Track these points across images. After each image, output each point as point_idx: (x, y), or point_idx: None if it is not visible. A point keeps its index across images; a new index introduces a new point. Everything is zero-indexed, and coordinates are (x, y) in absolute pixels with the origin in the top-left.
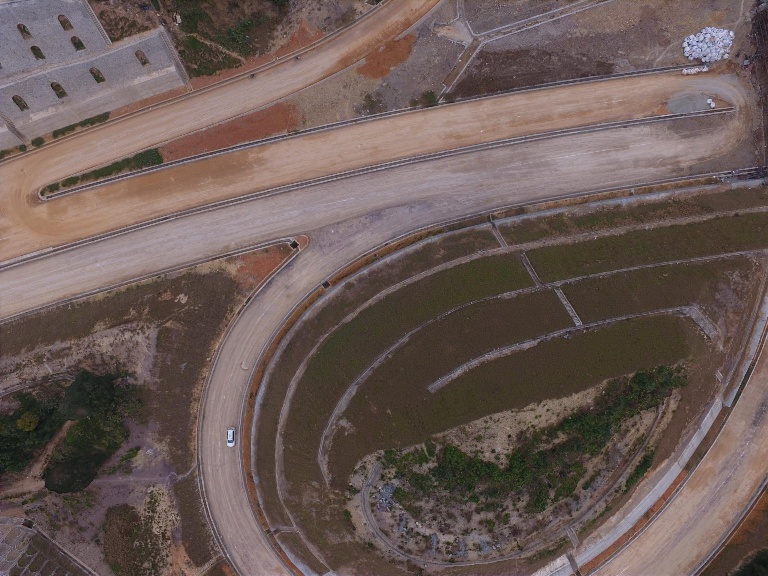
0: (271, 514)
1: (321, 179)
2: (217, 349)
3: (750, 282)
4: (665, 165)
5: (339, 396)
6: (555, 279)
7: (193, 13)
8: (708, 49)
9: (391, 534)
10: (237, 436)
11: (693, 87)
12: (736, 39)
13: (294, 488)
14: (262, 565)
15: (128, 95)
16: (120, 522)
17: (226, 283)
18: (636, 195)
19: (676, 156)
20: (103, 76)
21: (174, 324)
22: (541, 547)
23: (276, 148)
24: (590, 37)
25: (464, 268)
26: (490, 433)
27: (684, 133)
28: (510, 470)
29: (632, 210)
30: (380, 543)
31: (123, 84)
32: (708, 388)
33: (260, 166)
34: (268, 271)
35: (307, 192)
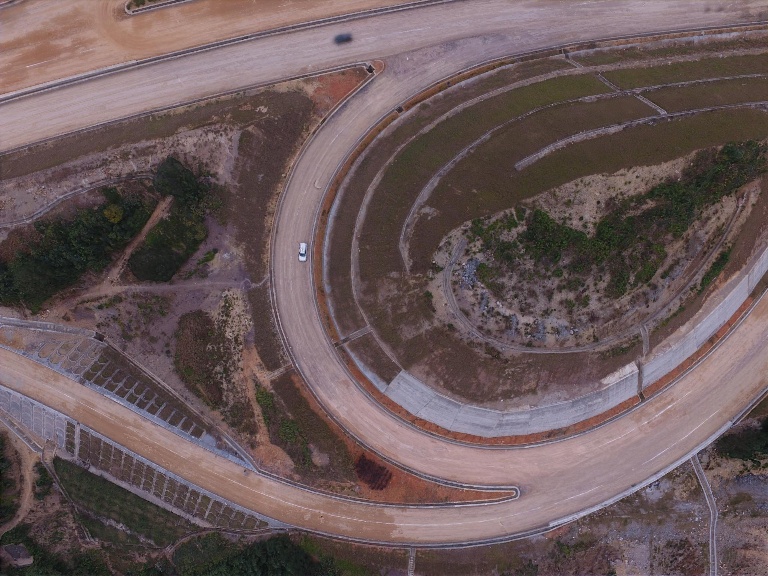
0: (342, 322)
1: (398, 7)
2: (292, 166)
3: None
4: (735, 10)
5: (421, 186)
6: (635, 86)
7: None
8: None
9: (472, 313)
10: (309, 252)
11: None
12: None
13: (370, 286)
14: (329, 377)
15: None
16: (194, 326)
17: (303, 101)
18: None
19: (746, 2)
20: None
21: (255, 130)
22: (615, 342)
23: None
24: None
25: (541, 84)
26: (579, 198)
27: None
28: (597, 237)
29: (704, 45)
30: (460, 324)
31: None
32: None
33: None
34: (344, 93)
35: (384, 19)
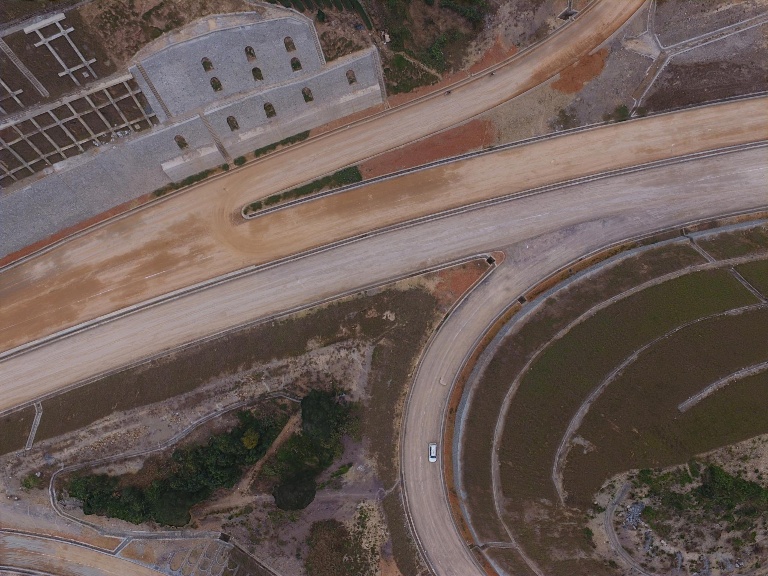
0: (480, 529)
1: (516, 195)
2: (417, 365)
3: None
4: None
5: (572, 414)
6: None
7: (401, 32)
8: None
9: (635, 552)
10: (438, 451)
11: None
12: None
13: (515, 504)
14: None
15: (331, 114)
16: (329, 537)
17: (427, 299)
18: None
19: None
20: (312, 96)
21: (386, 341)
22: None
23: (471, 164)
24: None
25: (676, 284)
26: (756, 453)
27: None
28: None
29: None
30: (622, 561)
31: (329, 103)
32: None
33: (456, 182)
34: (466, 287)
35: (502, 208)
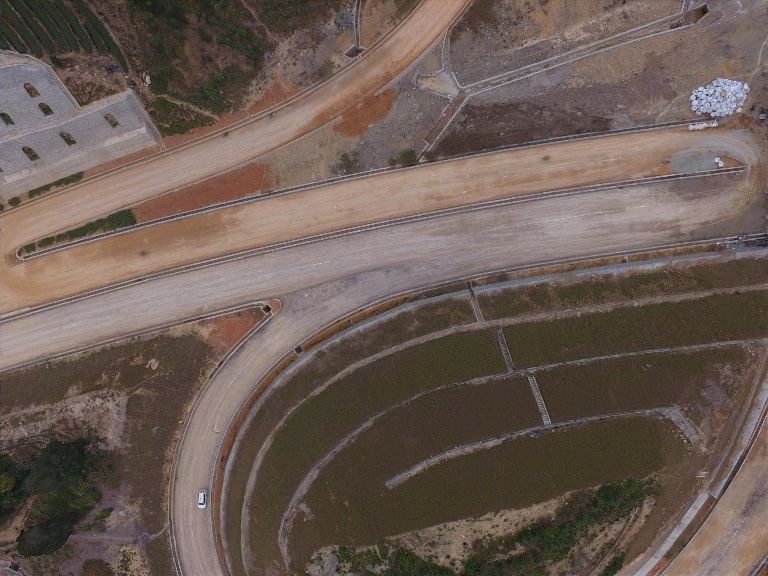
0: None
1: (295, 242)
2: (189, 412)
3: (742, 376)
4: (664, 229)
5: (300, 479)
6: (529, 365)
7: (163, 73)
8: (718, 104)
9: None
10: (208, 498)
11: (700, 144)
12: (751, 91)
13: (258, 561)
14: None
15: (100, 156)
16: None
17: (198, 347)
18: (629, 262)
19: (676, 220)
20: (74, 139)
21: (144, 391)
22: None
23: (250, 209)
24: (587, 88)
25: (436, 345)
26: (444, 540)
27: (687, 195)
28: None
29: (623, 281)
30: None
31: (94, 146)
32: (687, 490)
33: (233, 227)
34: (240, 335)
35: (281, 255)
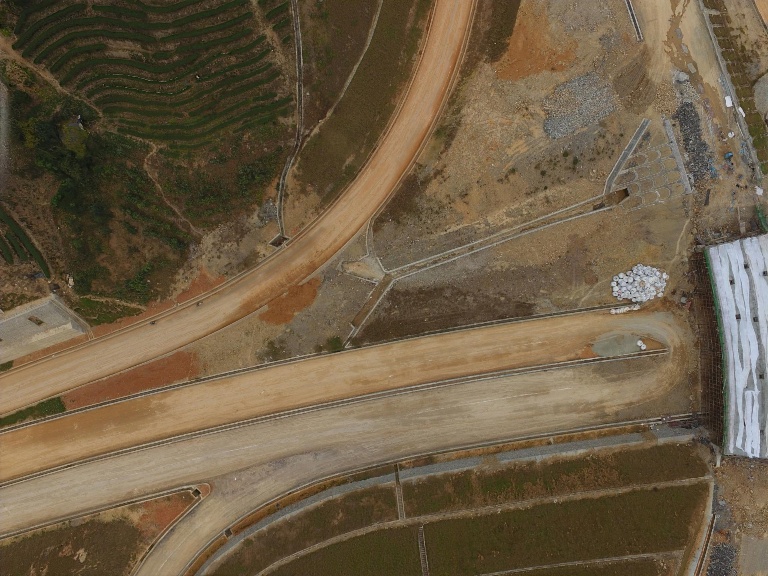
0: None
1: (223, 427)
2: None
3: None
4: (588, 411)
5: None
6: None
7: (86, 275)
8: (637, 294)
9: None
10: None
11: (622, 327)
12: (671, 278)
13: None
14: None
15: (28, 348)
16: None
17: (128, 533)
18: (554, 445)
19: (601, 401)
20: None
21: None
22: None
23: (178, 394)
24: (511, 271)
25: (358, 544)
26: None
27: (611, 376)
28: None
29: (545, 470)
30: None
31: (21, 342)
32: None
33: (162, 413)
34: (170, 519)
35: (210, 439)
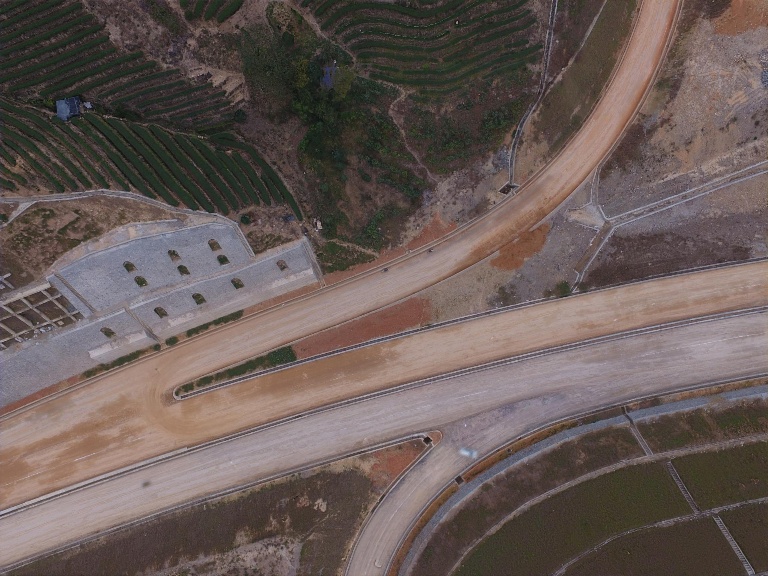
0: None
1: (454, 373)
2: (351, 548)
3: None
4: None
5: None
6: (713, 505)
7: (333, 218)
8: None
9: None
10: None
11: None
12: None
13: None
14: None
15: (264, 296)
16: None
17: (361, 483)
18: None
19: None
20: (243, 283)
21: (316, 535)
22: None
23: (408, 342)
24: (724, 218)
25: (611, 480)
26: None
27: None
28: None
29: None
30: None
31: (261, 288)
32: None
33: (393, 360)
34: (402, 468)
35: (440, 386)
